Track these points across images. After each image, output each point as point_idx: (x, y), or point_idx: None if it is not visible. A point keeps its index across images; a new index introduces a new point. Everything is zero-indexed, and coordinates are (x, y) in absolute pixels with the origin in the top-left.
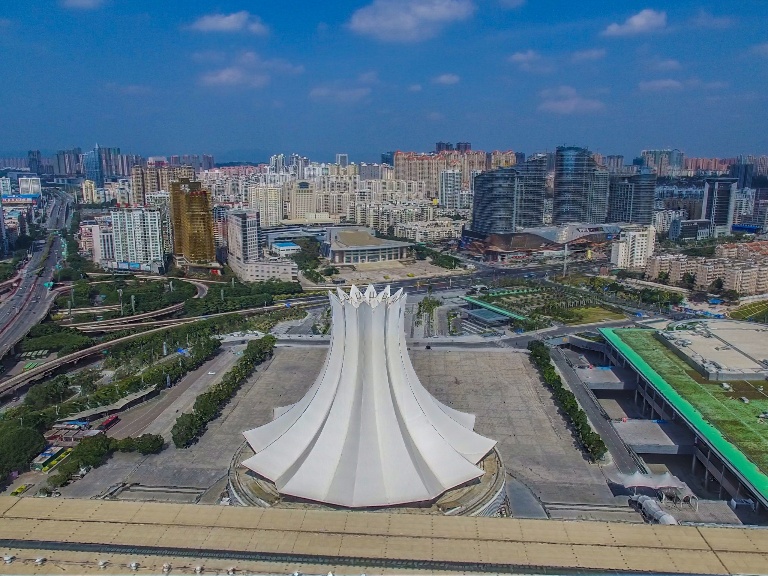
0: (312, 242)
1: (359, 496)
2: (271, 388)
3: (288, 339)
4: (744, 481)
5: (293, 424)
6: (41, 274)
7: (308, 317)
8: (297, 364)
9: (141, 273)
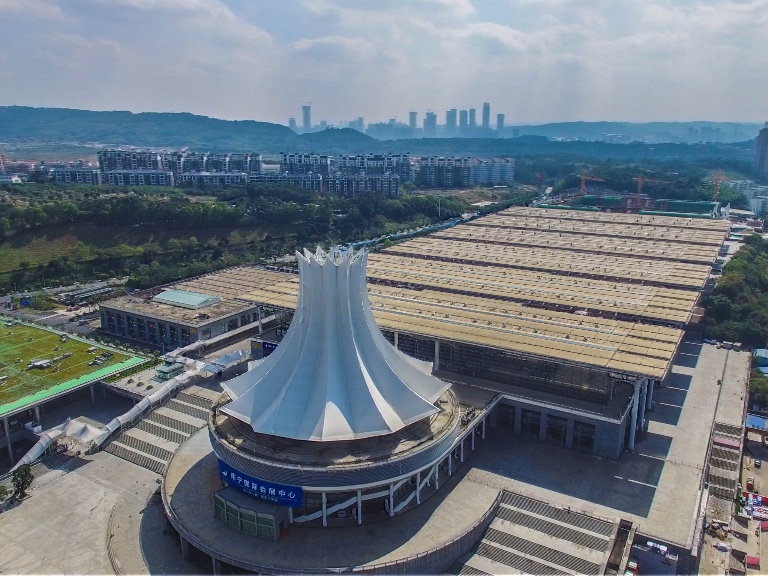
0: None
1: None
2: None
3: None
4: None
5: None
6: None
7: None
8: None
9: None
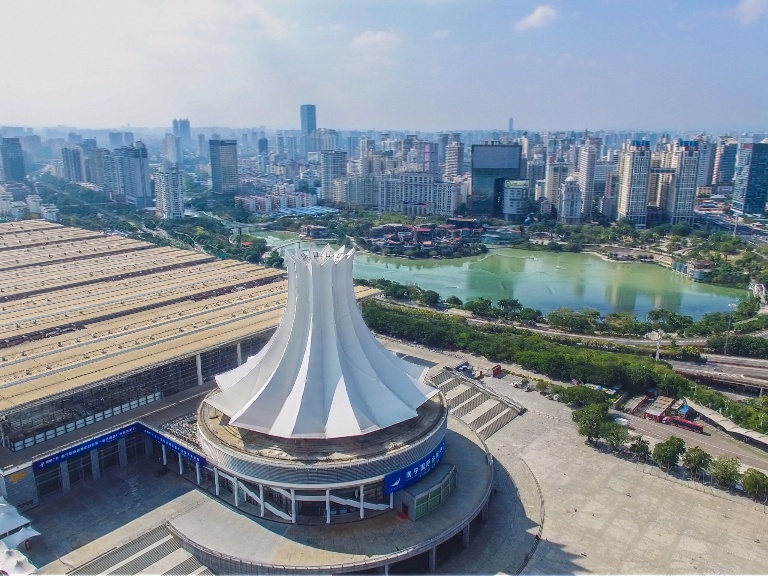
0: None
1: None
2: None
3: None
4: None
5: None
6: None
7: None
8: None
9: None
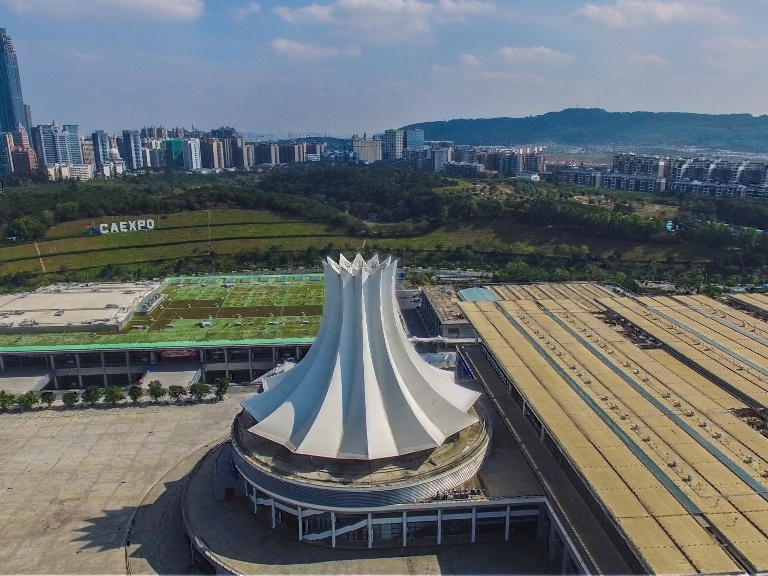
0: None
1: None
2: None
3: None
4: (299, 344)
5: (406, 398)
6: None
7: None
8: None
9: None
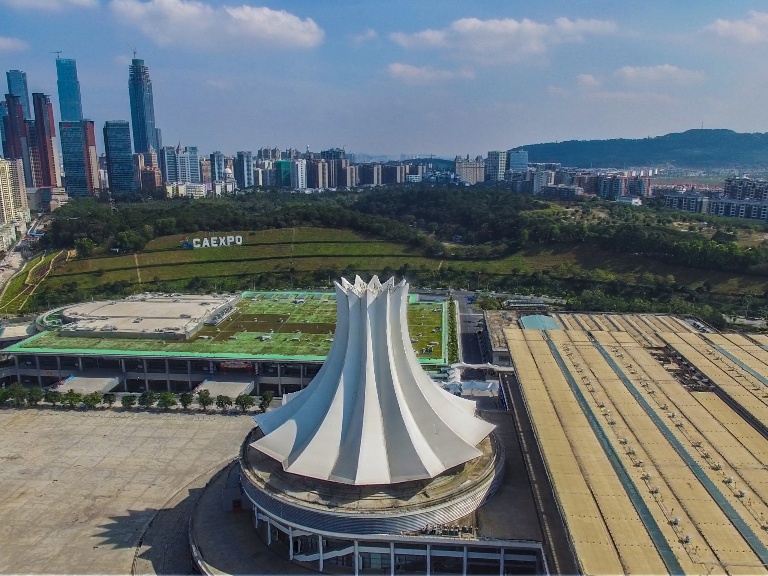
0: None
1: None
2: None
3: None
4: None
5: (405, 425)
6: None
7: None
8: None
9: None
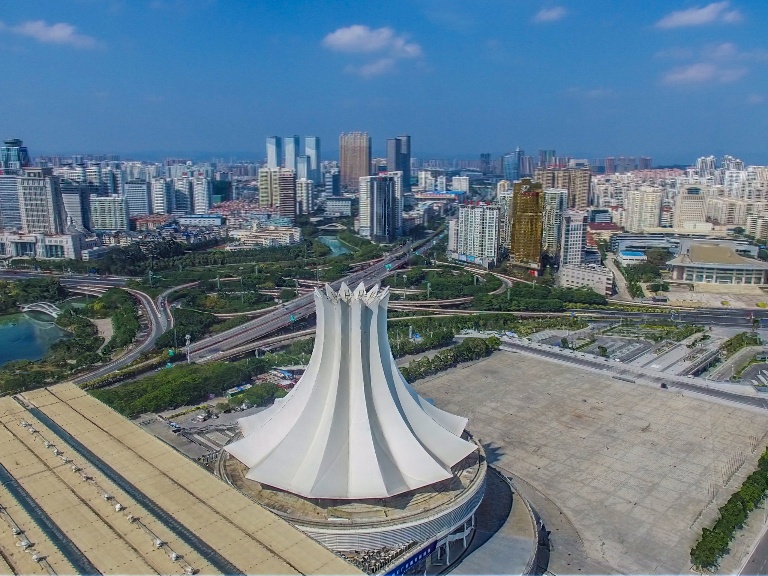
0: (668, 254)
1: (261, 471)
2: (449, 384)
3: (526, 346)
4: None
5: (281, 399)
6: (401, 258)
7: (583, 330)
8: (499, 369)
9: (474, 266)
